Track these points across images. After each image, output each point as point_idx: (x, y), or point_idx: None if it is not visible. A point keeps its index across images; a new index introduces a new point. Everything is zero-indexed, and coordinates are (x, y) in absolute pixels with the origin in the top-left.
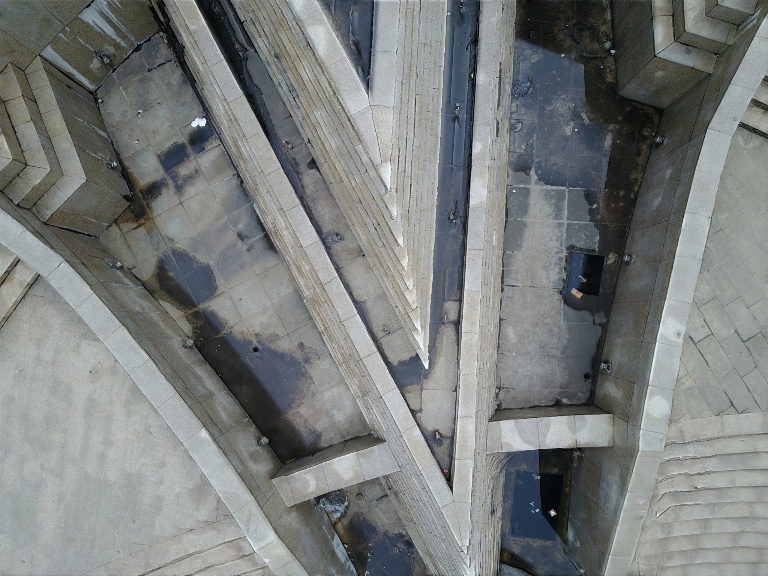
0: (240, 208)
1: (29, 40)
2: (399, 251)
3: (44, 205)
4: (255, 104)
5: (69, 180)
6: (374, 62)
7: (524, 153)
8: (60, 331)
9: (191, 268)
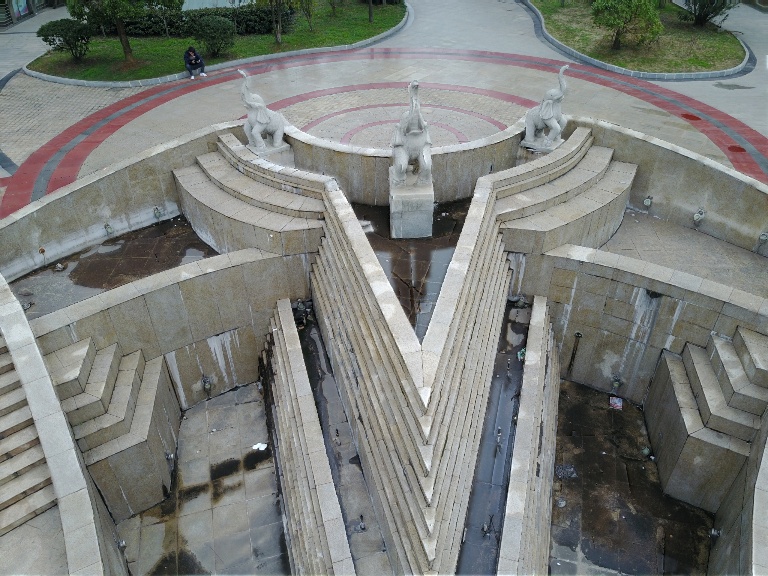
0: (267, 525)
1: (164, 340)
2: (425, 482)
3: (97, 452)
4: (319, 409)
5: (131, 437)
6: (430, 327)
7: (569, 529)
8: (30, 567)
9: (191, 574)
